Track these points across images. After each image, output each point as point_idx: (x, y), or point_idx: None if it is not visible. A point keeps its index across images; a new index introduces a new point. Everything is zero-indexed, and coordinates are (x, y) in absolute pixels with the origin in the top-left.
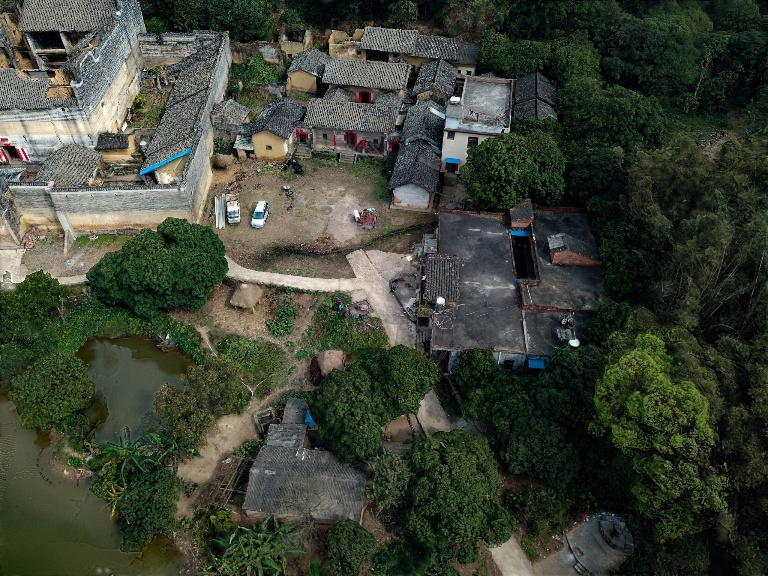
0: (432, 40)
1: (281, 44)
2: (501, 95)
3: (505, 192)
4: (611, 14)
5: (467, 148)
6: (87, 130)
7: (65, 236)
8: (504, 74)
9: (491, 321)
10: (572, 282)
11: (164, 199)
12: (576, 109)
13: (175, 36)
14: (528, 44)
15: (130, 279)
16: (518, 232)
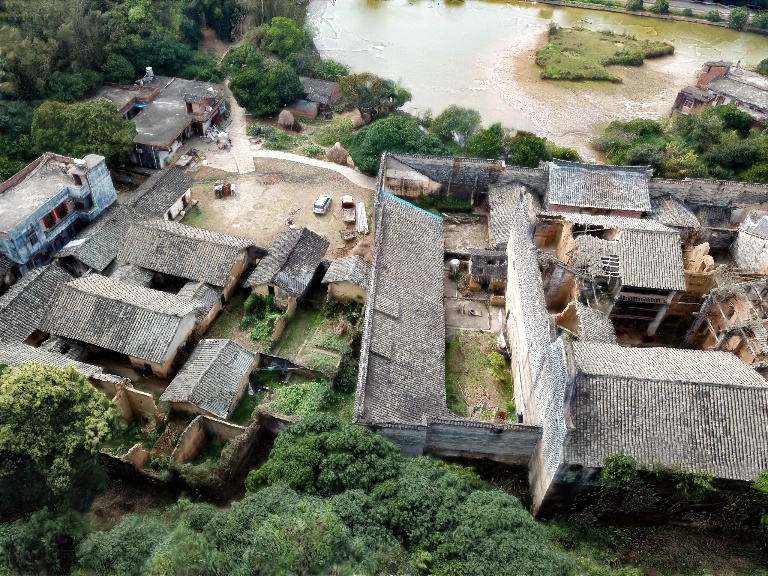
0: None
1: None
2: None
3: None
4: None
5: None
6: None
7: None
8: None
9: None
10: None
11: None
12: None
13: None
14: None
15: None
16: None
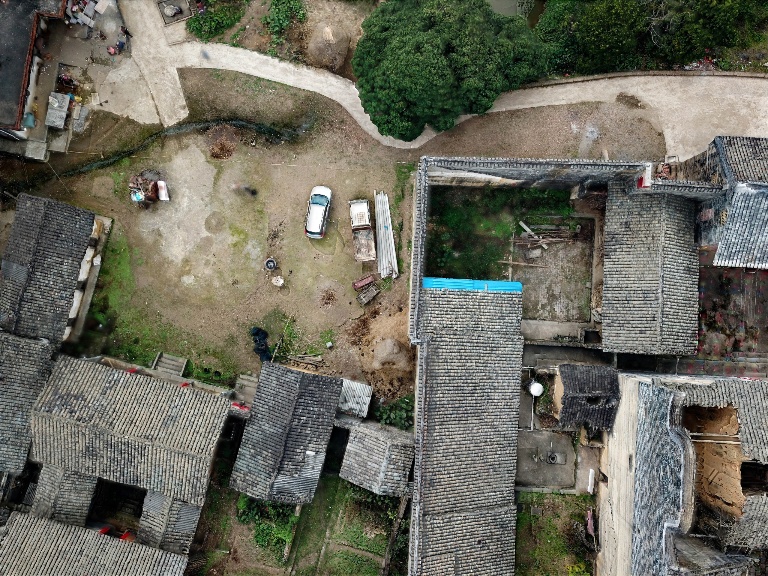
0: None
1: None
2: None
3: None
4: None
5: None
6: None
7: None
8: None
9: None
10: None
11: None
12: None
13: None
14: None
15: None
16: None
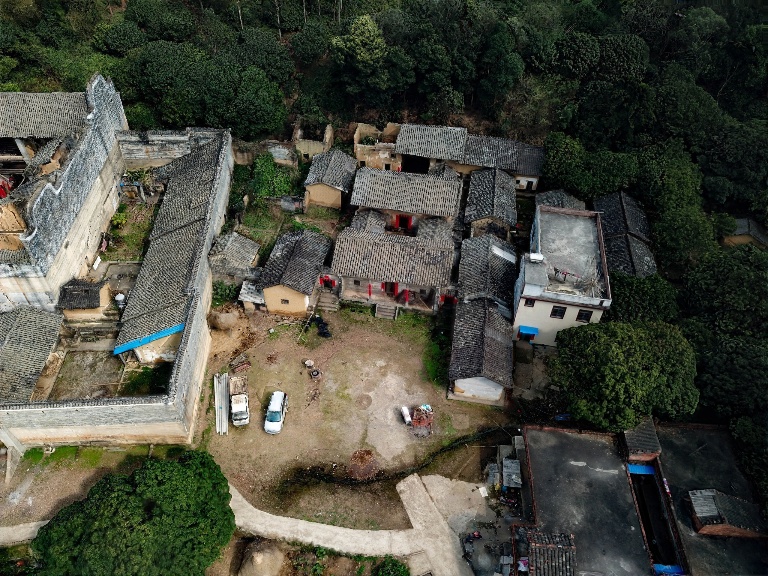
0: (485, 143)
1: (296, 142)
2: (586, 236)
3: (623, 417)
4: (712, 119)
5: (550, 317)
6: (44, 287)
7: (7, 456)
8: (579, 193)
9: None
10: (733, 572)
11: (145, 413)
12: (679, 251)
13: (163, 135)
14: (611, 158)
15: (92, 575)
16: (638, 467)
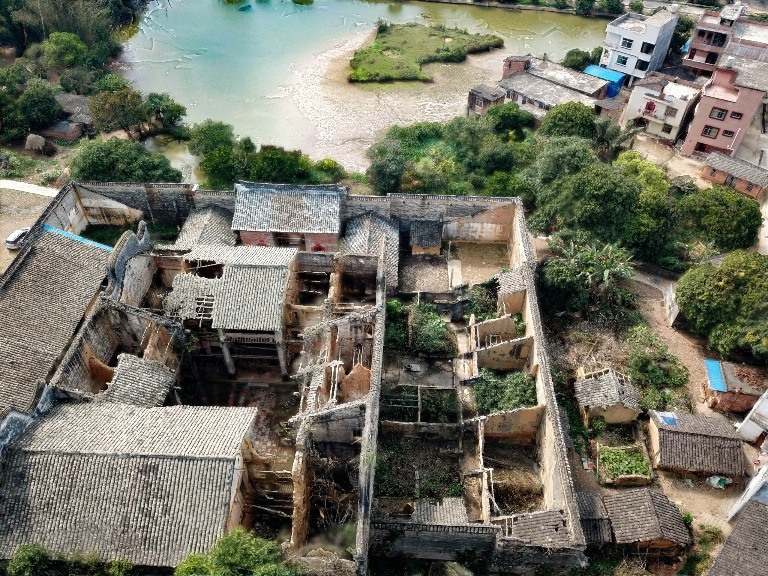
0: None
1: None
2: None
3: None
4: None
5: None
6: None
7: None
8: None
9: None
10: None
11: None
12: None
13: None
14: None
15: None
16: None
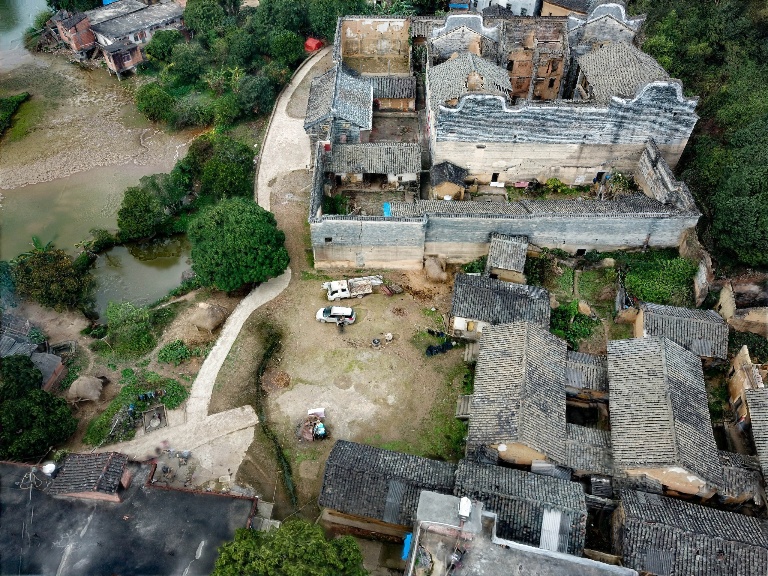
0: None
1: (725, 285)
2: None
3: None
4: None
5: None
6: None
7: None
8: None
9: (7, 539)
10: None
11: None
12: None
13: None
14: None
15: None
16: None
